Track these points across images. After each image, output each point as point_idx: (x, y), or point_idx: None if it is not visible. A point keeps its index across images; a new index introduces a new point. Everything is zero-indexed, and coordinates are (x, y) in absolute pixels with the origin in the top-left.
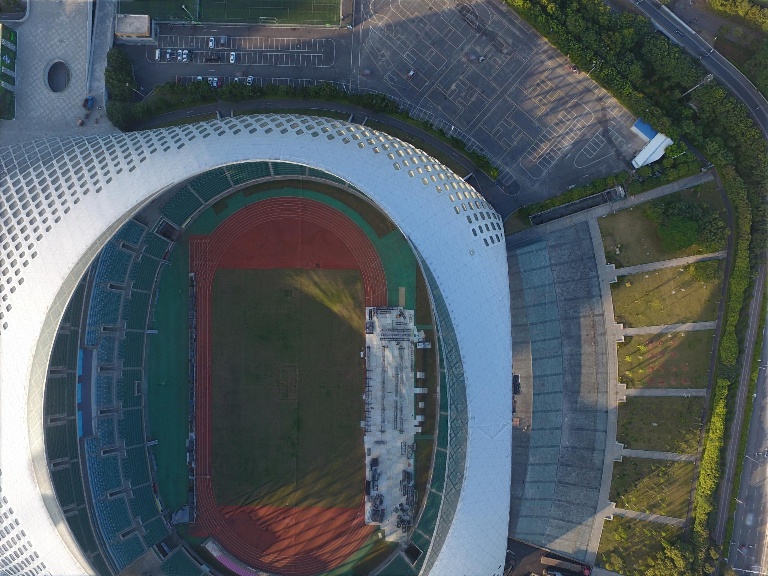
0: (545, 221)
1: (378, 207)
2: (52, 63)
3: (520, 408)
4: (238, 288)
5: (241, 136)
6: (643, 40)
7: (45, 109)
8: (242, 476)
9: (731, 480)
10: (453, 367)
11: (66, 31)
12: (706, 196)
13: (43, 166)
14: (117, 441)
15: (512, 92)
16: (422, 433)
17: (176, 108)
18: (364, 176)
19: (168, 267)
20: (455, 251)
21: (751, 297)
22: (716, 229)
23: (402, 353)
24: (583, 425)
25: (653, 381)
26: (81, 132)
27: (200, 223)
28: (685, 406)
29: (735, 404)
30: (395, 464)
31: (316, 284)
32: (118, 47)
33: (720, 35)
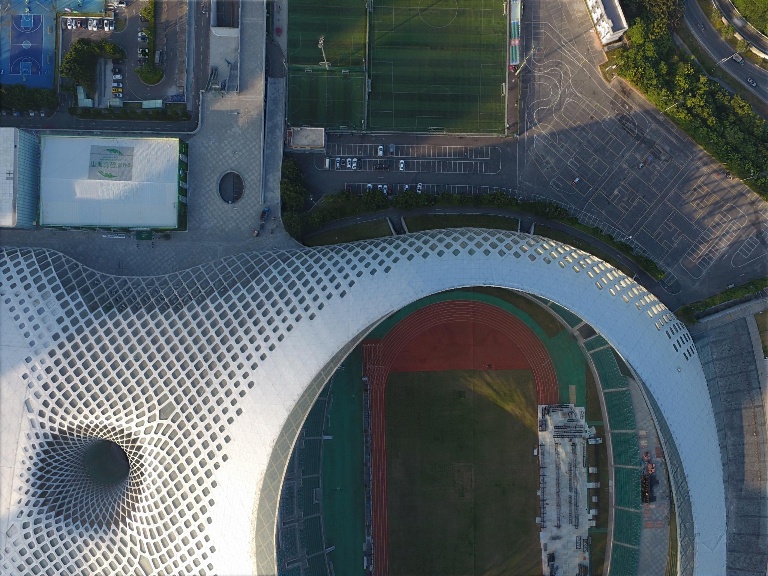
0: (701, 316)
1: (549, 309)
2: (224, 174)
3: None
4: (412, 391)
5: (447, 259)
6: None
7: (219, 220)
8: None
9: None
10: (680, 487)
11: (239, 142)
12: None
13: (243, 289)
14: (299, 551)
15: (671, 197)
16: (597, 527)
17: (347, 215)
18: (576, 299)
19: (341, 372)
20: (666, 370)
21: None
22: None
23: (575, 449)
24: (748, 512)
25: None
26: (256, 242)
27: None
28: None
29: None
30: (571, 558)
31: (489, 384)
32: None
33: None
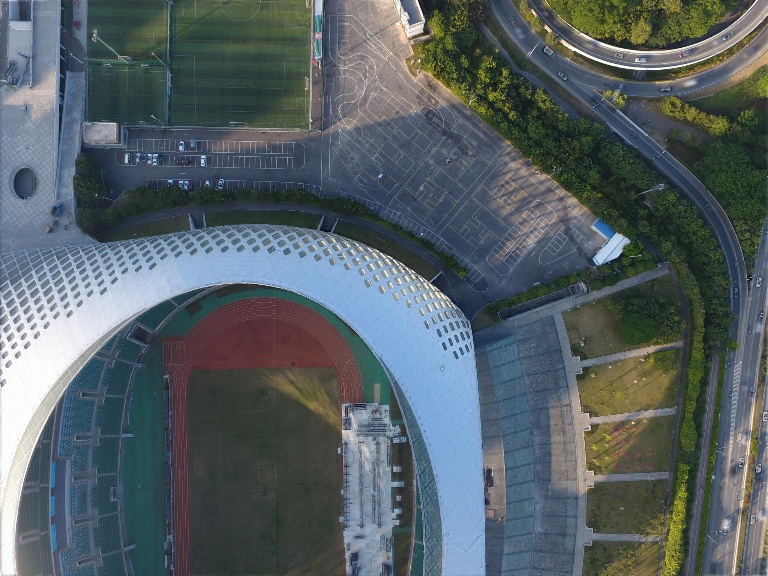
0: (513, 314)
1: None
2: (18, 169)
3: (494, 500)
4: (214, 389)
5: (213, 256)
6: (600, 145)
7: (12, 216)
8: None
9: (694, 558)
10: (427, 487)
11: (32, 138)
12: (663, 289)
13: (11, 286)
14: (93, 550)
15: (478, 193)
16: (400, 526)
17: (147, 212)
18: (336, 297)
19: (142, 370)
20: (426, 369)
21: (707, 384)
22: (672, 323)
23: (378, 448)
24: (554, 512)
25: (619, 467)
26: (50, 239)
27: (174, 325)
28: (649, 489)
29: (696, 485)
30: (374, 558)
31: (292, 383)
32: (86, 154)
33: (671, 137)
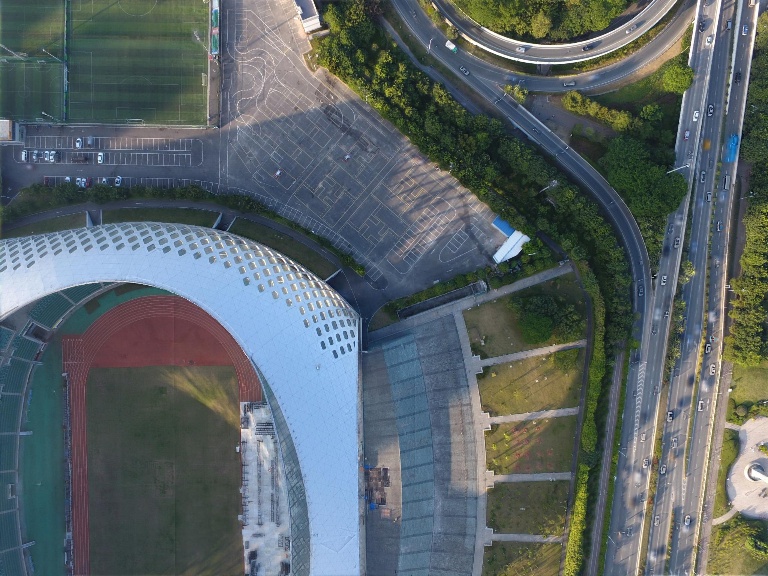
0: (415, 312)
1: None
2: None
3: (390, 500)
4: (112, 387)
5: (91, 254)
6: (499, 141)
7: None
8: (121, 573)
9: (597, 559)
10: (294, 487)
11: None
12: (565, 287)
13: None
14: None
15: (377, 190)
16: None
17: (44, 209)
18: (210, 295)
19: (41, 367)
20: (300, 368)
21: (610, 384)
22: (572, 322)
23: None
24: (454, 512)
25: (520, 467)
26: None
27: (72, 323)
28: (551, 490)
29: (598, 486)
30: (273, 556)
31: (190, 381)
32: None
33: (574, 133)
